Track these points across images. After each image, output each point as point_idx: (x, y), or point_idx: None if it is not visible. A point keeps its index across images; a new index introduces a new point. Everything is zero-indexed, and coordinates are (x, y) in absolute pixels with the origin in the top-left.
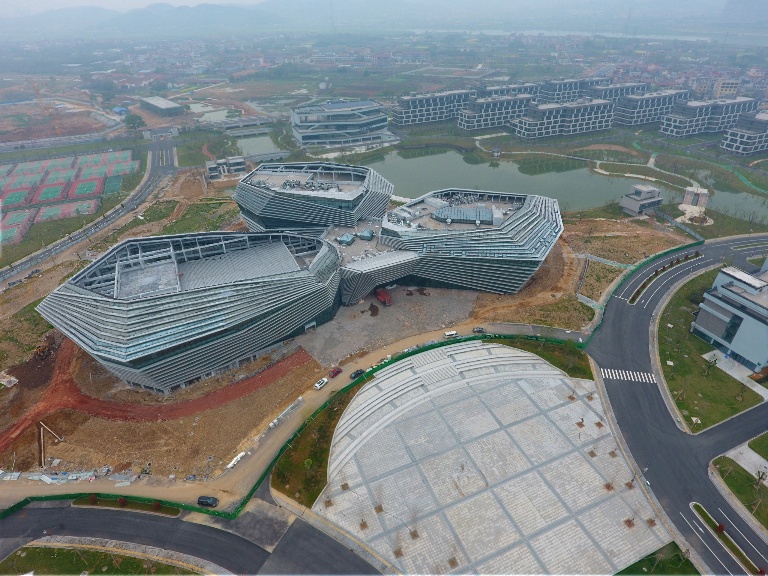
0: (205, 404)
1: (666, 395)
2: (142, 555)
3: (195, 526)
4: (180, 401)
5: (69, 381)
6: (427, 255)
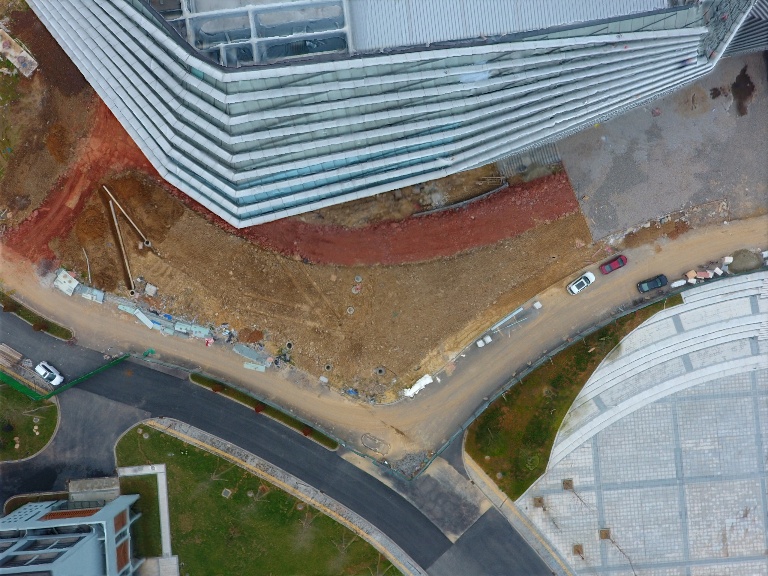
0: (372, 249)
1: None
2: (294, 491)
3: (358, 473)
4: (329, 224)
5: None
6: None
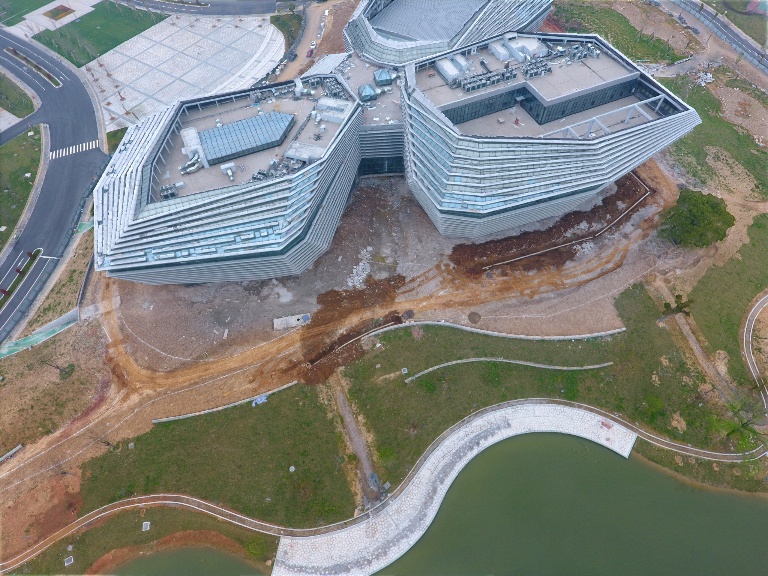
0: None
1: (46, 144)
2: None
3: None
4: None
5: None
6: None
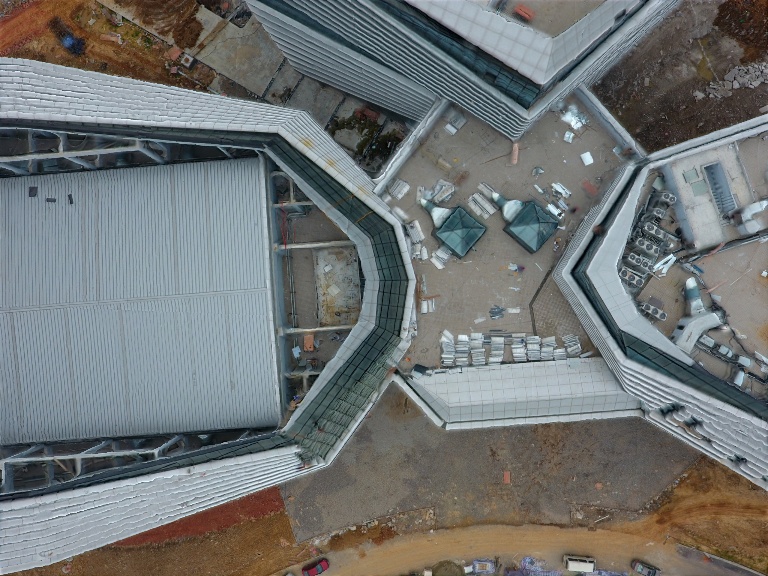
0: None
1: None
2: None
3: None
4: None
5: None
6: (661, 425)
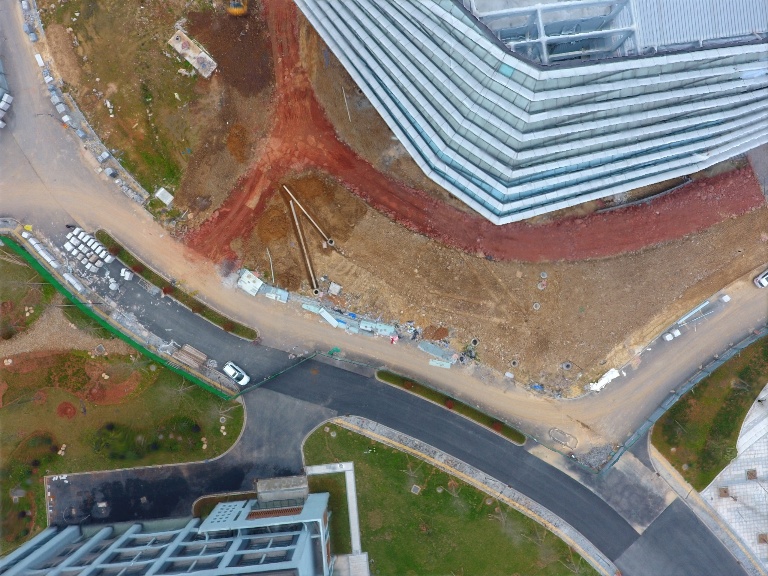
0: (556, 245)
1: None
2: (483, 487)
3: (546, 467)
4: None
5: (307, 95)
6: None
